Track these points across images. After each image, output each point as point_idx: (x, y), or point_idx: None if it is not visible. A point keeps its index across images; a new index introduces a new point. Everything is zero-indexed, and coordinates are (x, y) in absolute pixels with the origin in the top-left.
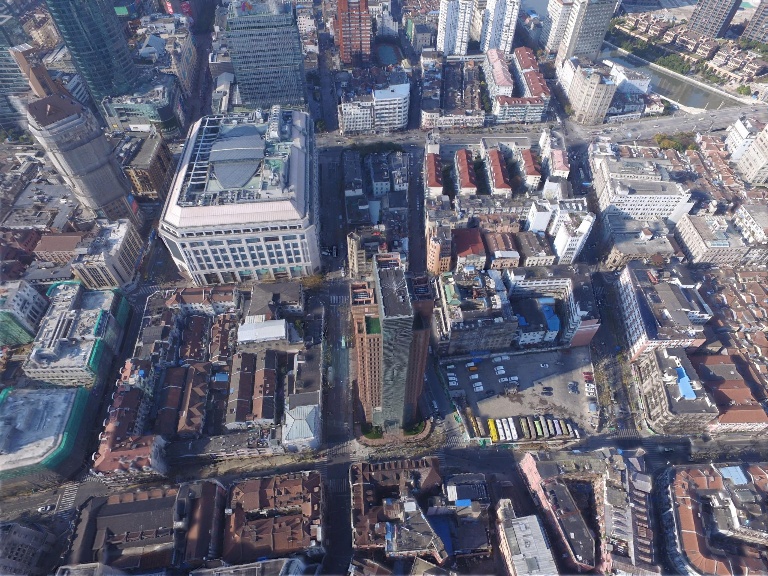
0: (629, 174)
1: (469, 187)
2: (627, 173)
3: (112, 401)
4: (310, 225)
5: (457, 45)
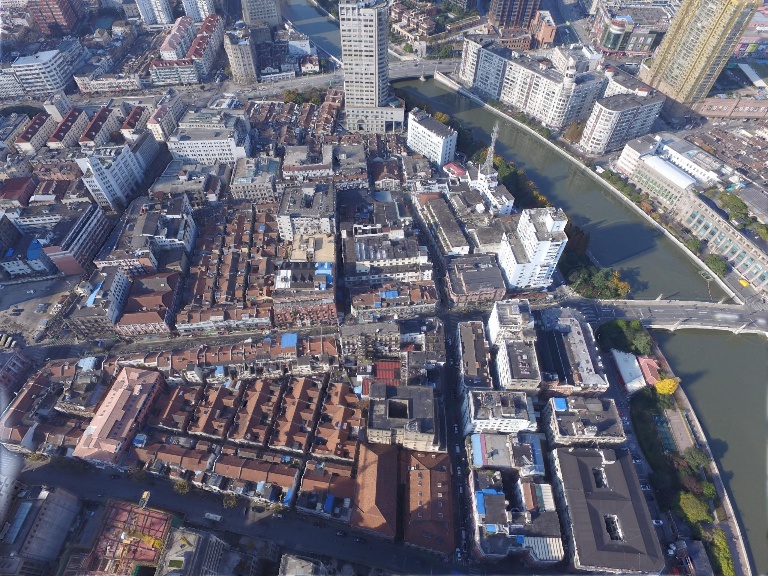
0: (196, 123)
1: (53, 142)
2: (193, 122)
3: None
4: None
5: (156, 14)
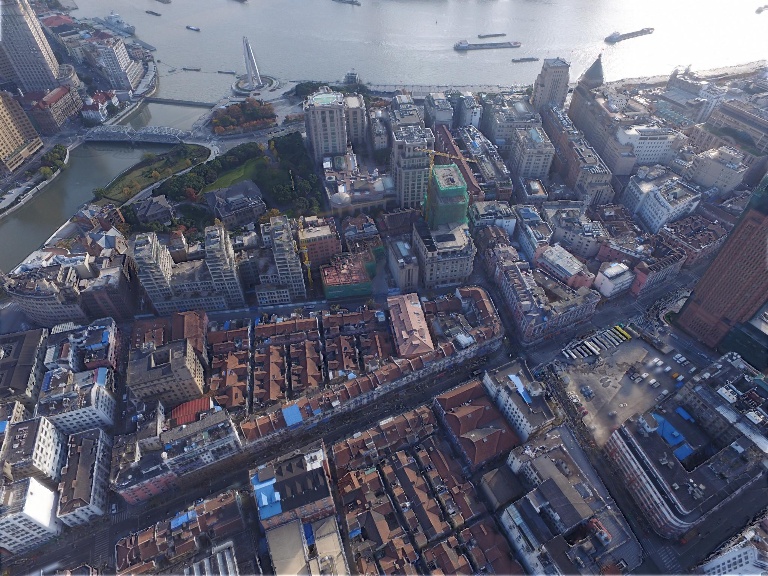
0: None
1: None
2: None
3: None
4: None
5: None
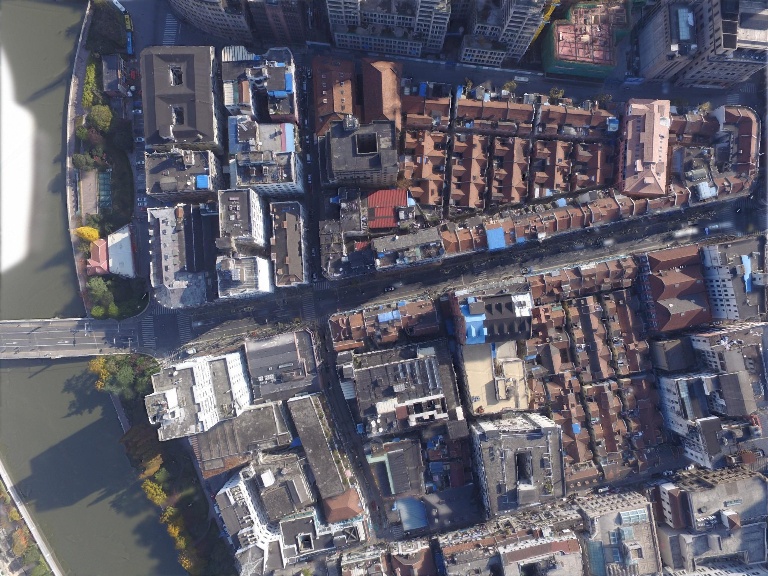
0: None
1: None
2: None
3: None
4: None
5: None
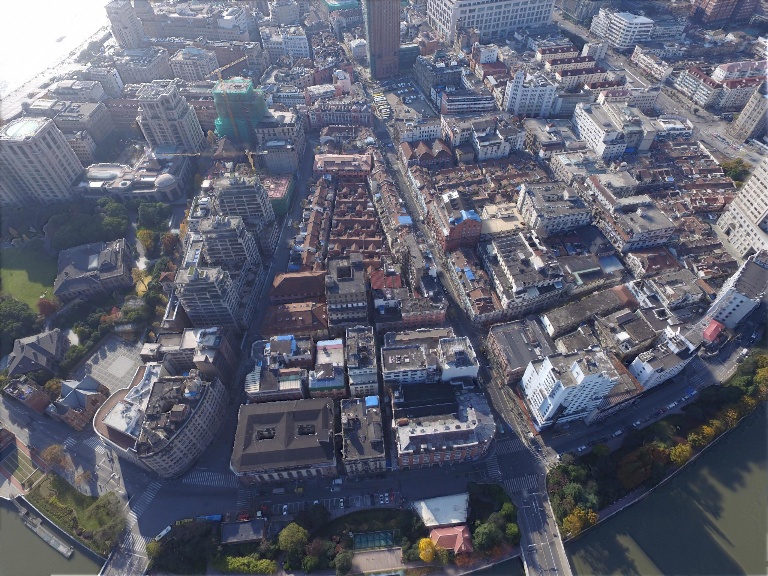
0: (612, 110)
1: (549, 63)
2: (612, 108)
3: (355, 8)
4: (458, 7)
5: None
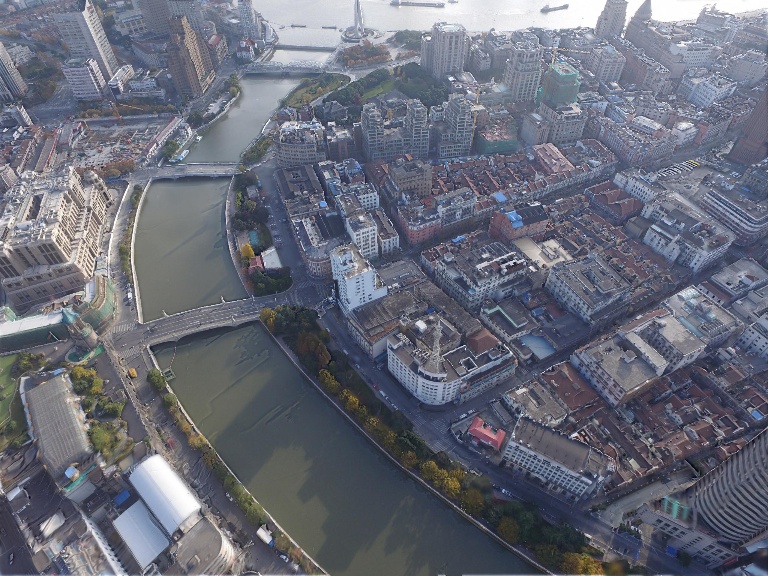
0: None
1: None
2: None
3: None
4: None
5: None
